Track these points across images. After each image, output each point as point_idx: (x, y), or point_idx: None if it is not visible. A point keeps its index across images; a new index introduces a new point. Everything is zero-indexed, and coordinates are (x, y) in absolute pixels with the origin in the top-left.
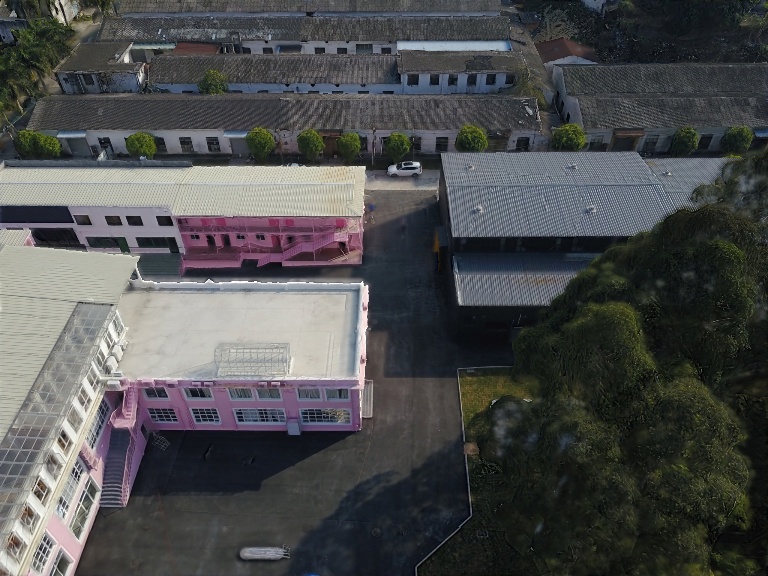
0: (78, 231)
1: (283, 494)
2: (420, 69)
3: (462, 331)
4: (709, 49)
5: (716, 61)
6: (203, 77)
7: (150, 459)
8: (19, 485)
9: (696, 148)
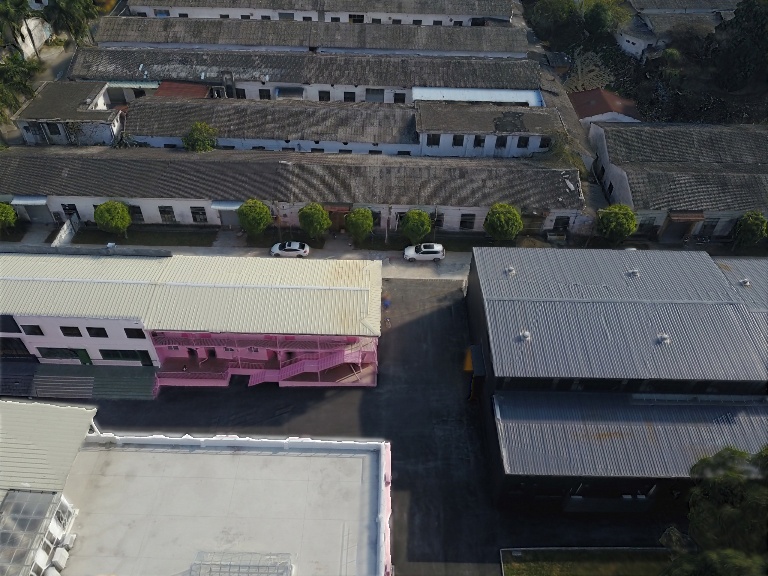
0: (27, 341)
1: None
2: (442, 128)
3: (505, 497)
4: (762, 106)
5: None
6: (189, 129)
7: None
8: None
9: (763, 236)
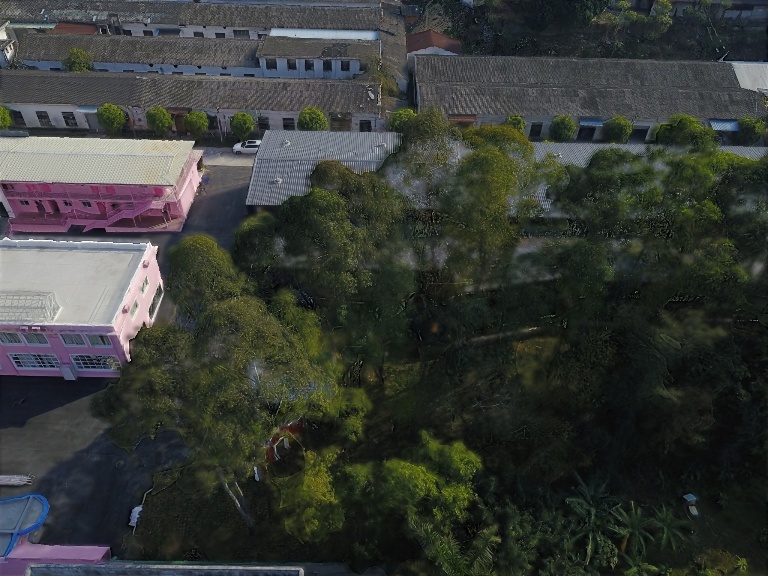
0: None
1: (44, 431)
2: (277, 54)
3: None
4: (568, 45)
5: (575, 56)
6: (70, 55)
7: None
8: None
9: (524, 134)
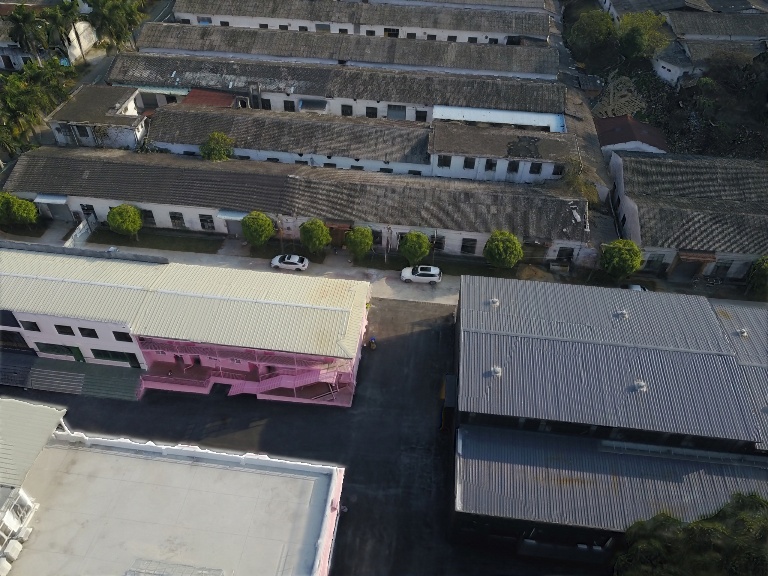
0: (26, 336)
1: None
2: (454, 150)
3: (458, 533)
4: None
5: None
6: (208, 138)
7: None
8: None
9: None
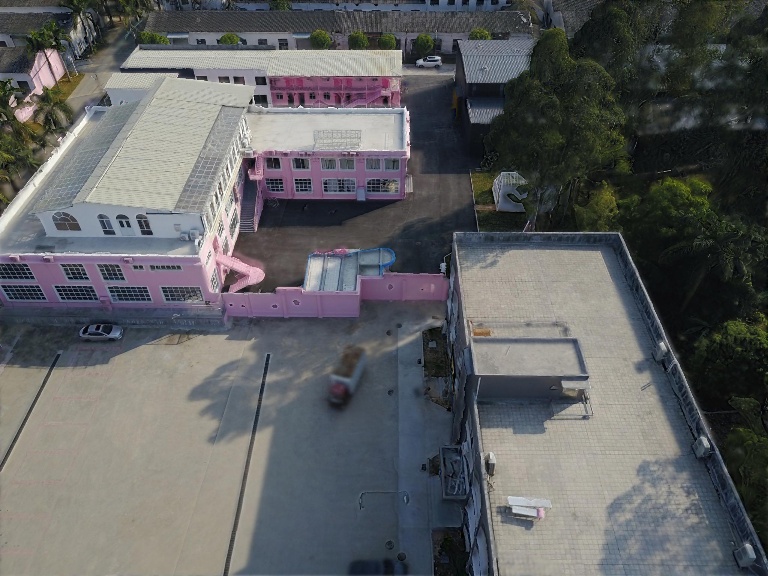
0: None
1: (357, 227)
2: None
3: (473, 146)
4: None
5: None
6: None
7: (267, 211)
8: (211, 179)
9: None
